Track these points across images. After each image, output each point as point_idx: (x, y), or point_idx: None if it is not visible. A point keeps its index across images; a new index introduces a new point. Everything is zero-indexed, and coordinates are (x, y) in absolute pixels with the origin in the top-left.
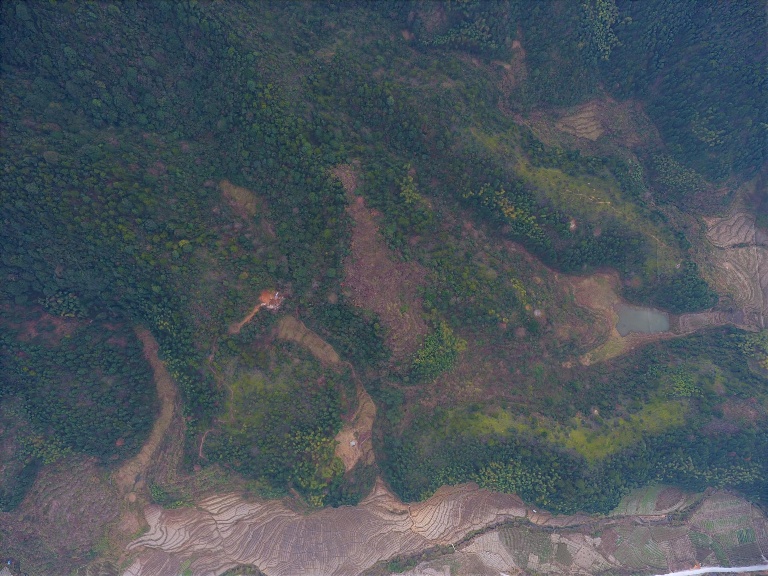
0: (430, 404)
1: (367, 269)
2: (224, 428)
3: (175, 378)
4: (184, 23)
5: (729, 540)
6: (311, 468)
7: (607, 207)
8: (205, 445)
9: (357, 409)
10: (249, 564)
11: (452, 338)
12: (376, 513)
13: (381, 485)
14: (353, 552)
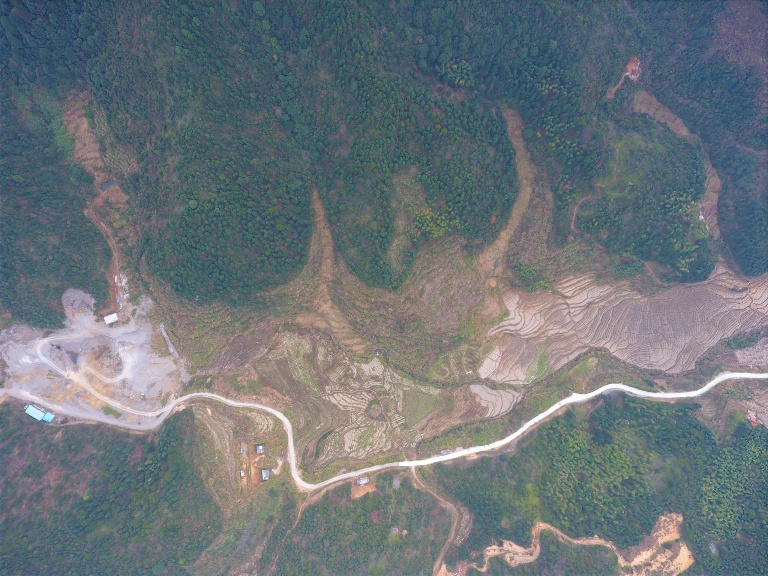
0: None
1: (742, 22)
2: (606, 190)
3: (553, 146)
4: None
5: None
6: (684, 230)
7: None
8: (580, 214)
9: (704, 183)
10: (600, 347)
11: None
12: (716, 292)
13: (721, 263)
14: (697, 331)
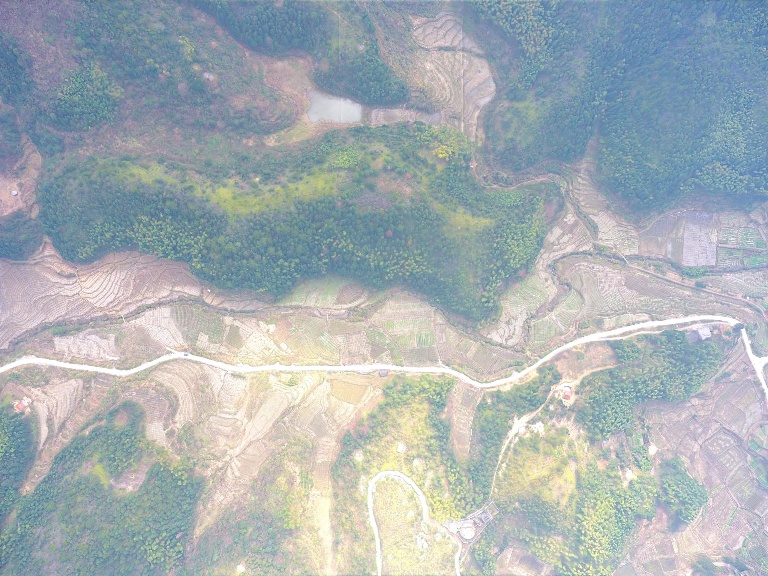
0: (87, 153)
1: None
2: None
3: None
4: None
5: (407, 342)
6: None
7: None
8: None
9: (21, 158)
10: None
11: (104, 81)
12: (44, 274)
13: (50, 245)
14: (16, 310)
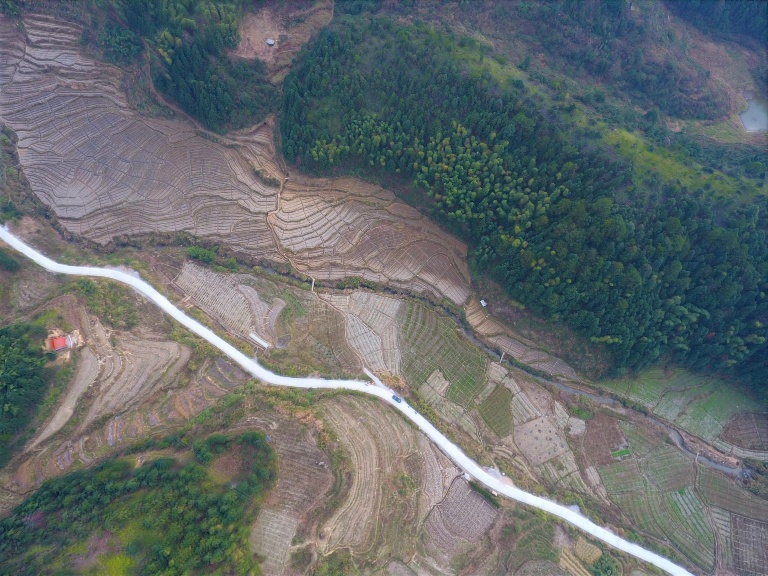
0: (411, 23)
1: None
2: None
3: None
4: None
5: None
6: None
7: None
8: None
9: (307, 8)
10: (11, 129)
11: None
12: (234, 165)
13: (269, 130)
14: (159, 196)
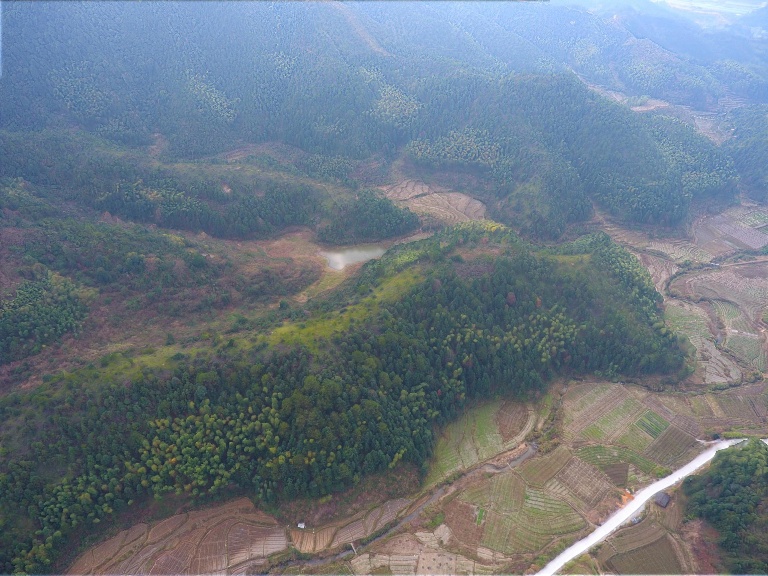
0: (38, 382)
1: None
2: None
3: None
4: None
5: (637, 440)
6: None
7: (258, 172)
8: None
9: None
10: None
11: (69, 284)
12: None
13: None
14: None
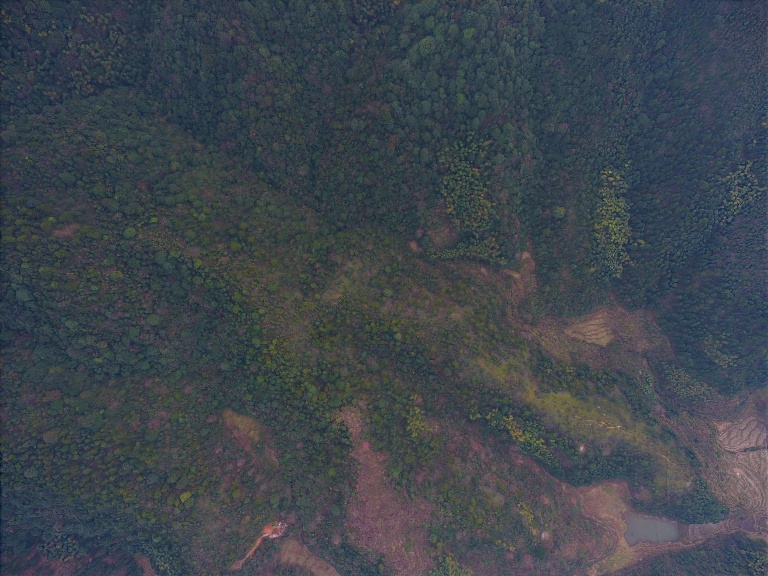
0: None
1: (372, 511)
2: None
3: None
4: (188, 280)
5: None
6: None
7: (617, 431)
8: None
9: None
10: None
11: (458, 571)
12: None
13: None
14: None
